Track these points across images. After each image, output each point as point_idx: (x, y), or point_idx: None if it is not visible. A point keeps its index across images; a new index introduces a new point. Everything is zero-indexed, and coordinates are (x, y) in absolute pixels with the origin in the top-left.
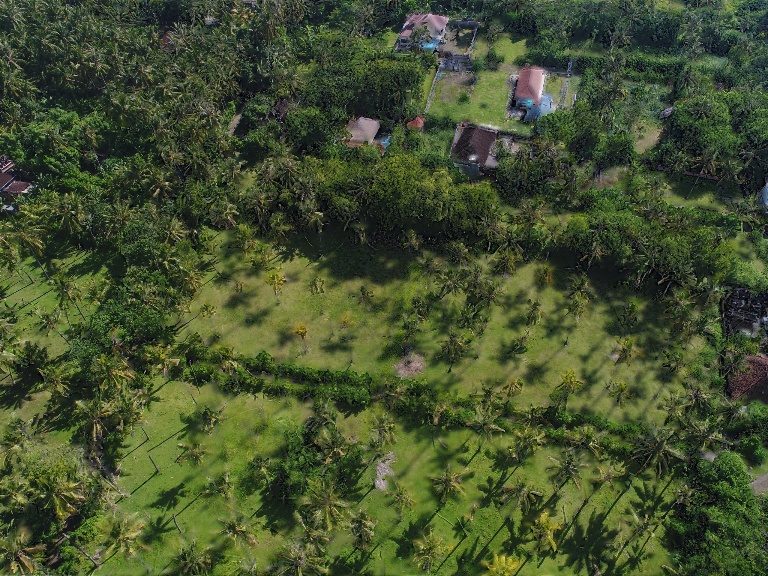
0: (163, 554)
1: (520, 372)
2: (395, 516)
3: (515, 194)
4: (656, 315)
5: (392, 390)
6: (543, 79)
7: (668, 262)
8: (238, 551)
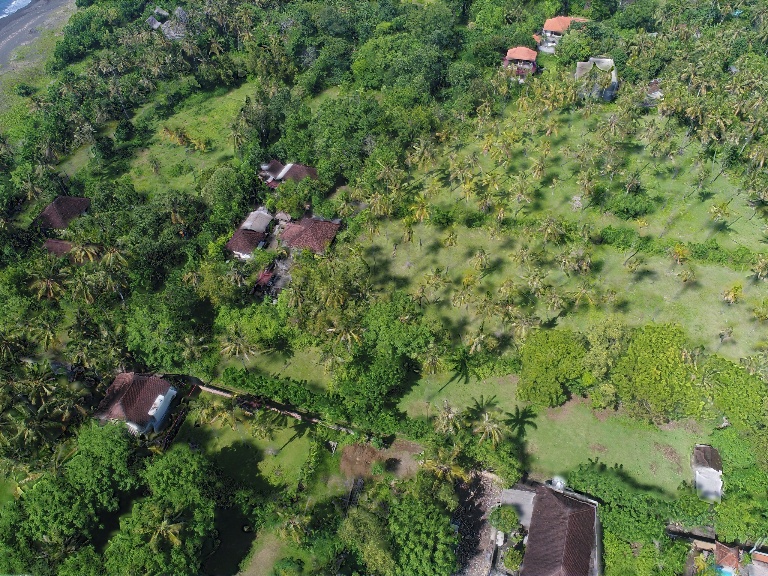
0: (689, 177)
1: None
2: (564, 189)
3: None
4: None
5: None
6: None
7: None
8: (648, 177)
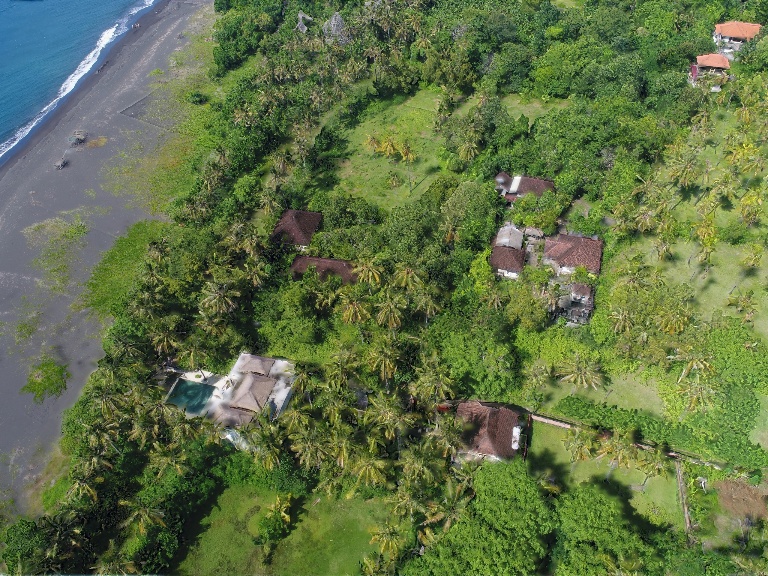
0: None
1: (762, 275)
2: None
3: None
4: None
5: None
6: None
7: None
8: None
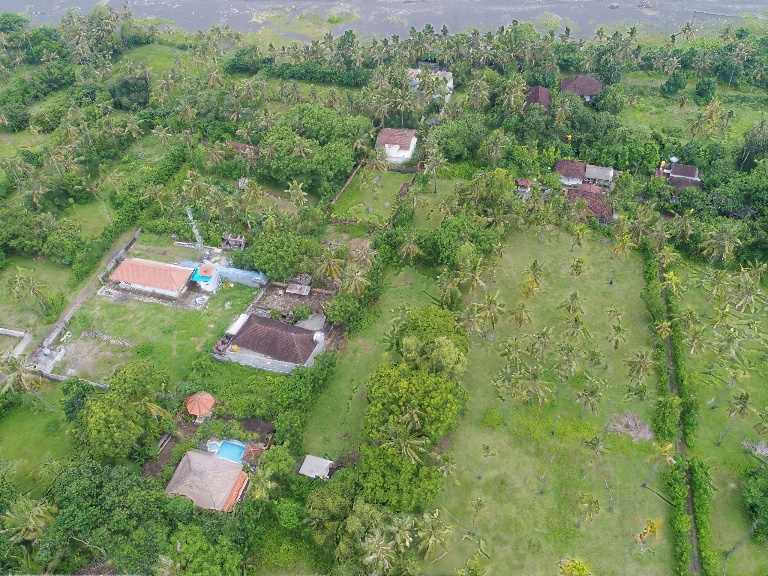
0: None
1: None
2: None
3: None
4: (524, 243)
5: (748, 399)
6: (142, 259)
7: (520, 204)
8: None
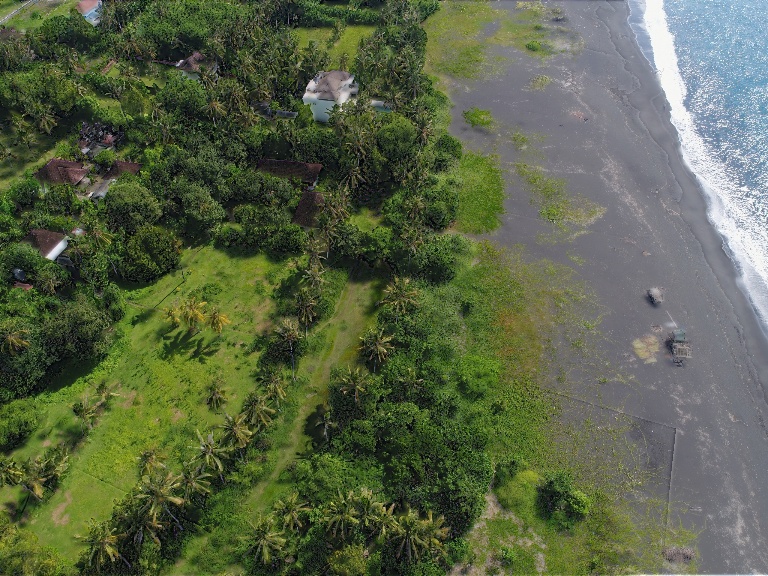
0: None
1: None
2: None
3: (10, 75)
4: None
5: None
6: None
7: (18, 98)
8: None
